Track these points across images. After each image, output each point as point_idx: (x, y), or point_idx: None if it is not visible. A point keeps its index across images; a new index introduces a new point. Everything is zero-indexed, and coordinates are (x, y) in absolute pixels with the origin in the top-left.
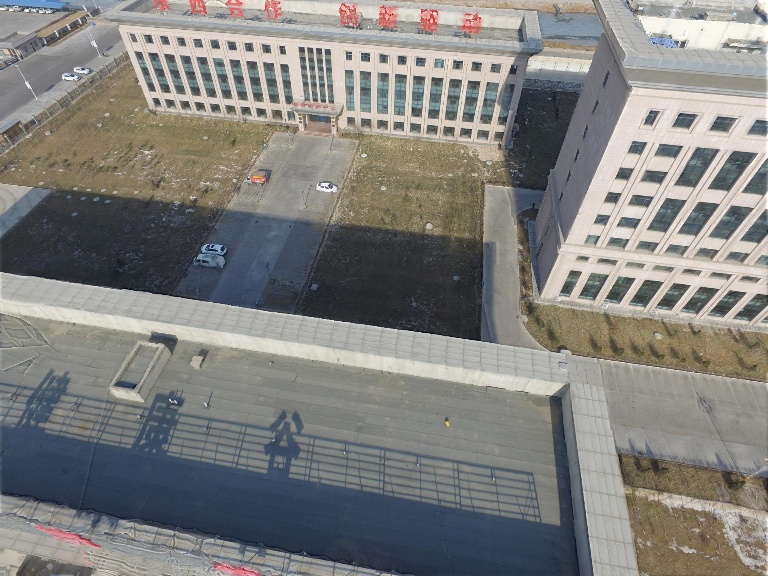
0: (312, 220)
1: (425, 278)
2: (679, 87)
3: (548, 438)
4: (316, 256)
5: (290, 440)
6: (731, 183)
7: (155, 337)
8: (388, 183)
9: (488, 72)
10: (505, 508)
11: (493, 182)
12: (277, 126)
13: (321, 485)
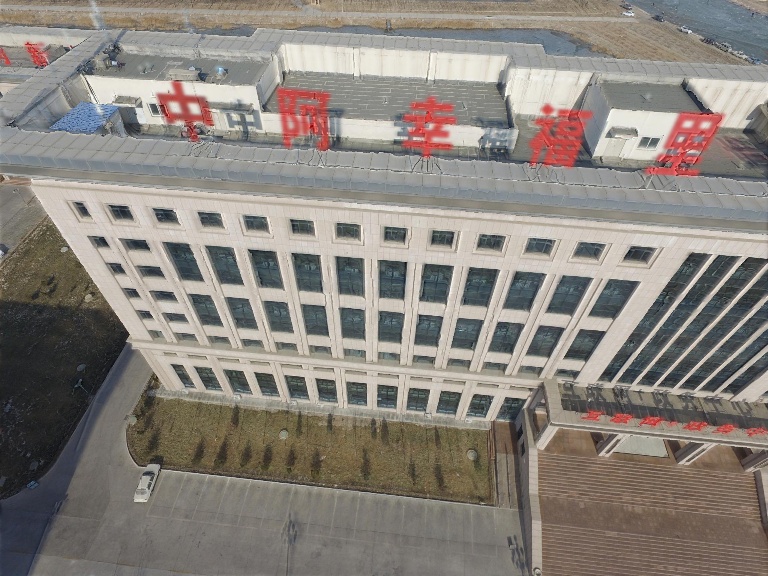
0: None
1: (43, 369)
2: (58, 179)
3: None
4: None
5: None
6: None
7: None
8: None
9: None
10: None
11: None
12: None
13: None
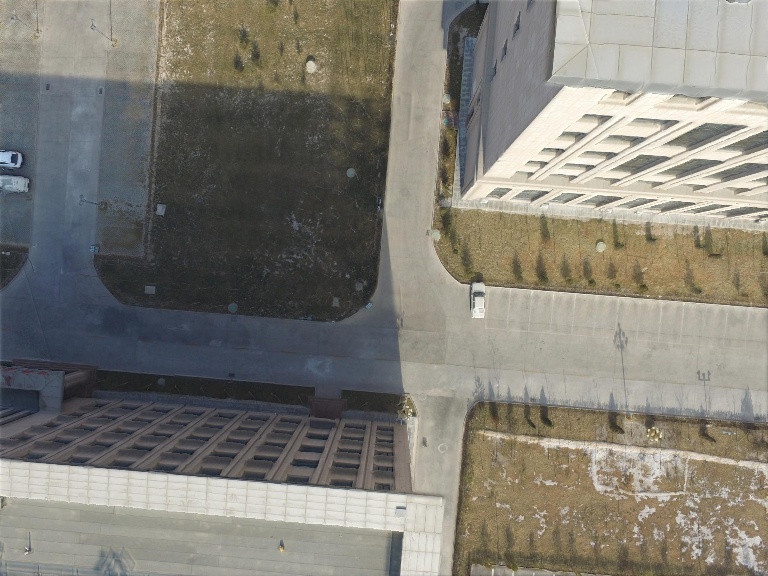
0: (130, 73)
1: (308, 176)
2: None
3: (385, 555)
4: (151, 152)
5: None
6: (753, 146)
7: None
8: None
9: None
10: None
11: None
12: None
13: None
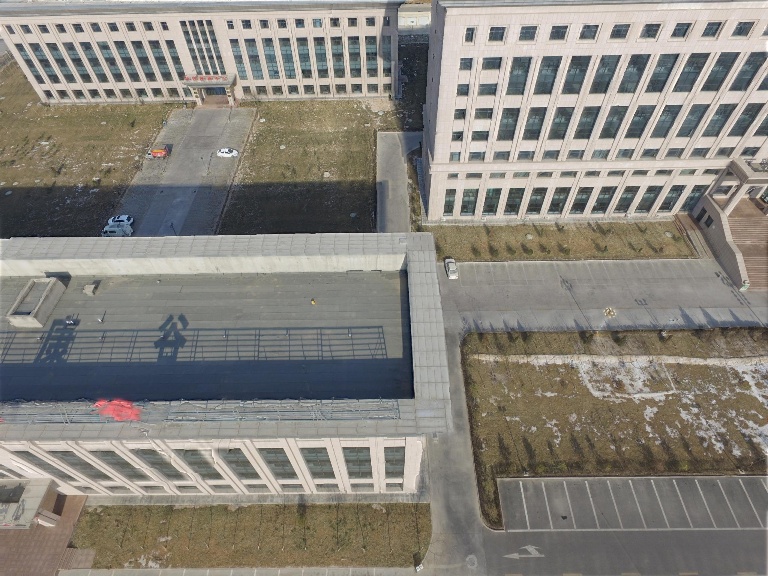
0: (215, 183)
1: (325, 219)
2: (481, 3)
3: (396, 300)
4: (221, 214)
5: (177, 335)
6: (551, 87)
7: (49, 277)
8: (287, 142)
9: (364, 26)
10: (359, 353)
11: (385, 129)
12: (175, 104)
13: (205, 362)
